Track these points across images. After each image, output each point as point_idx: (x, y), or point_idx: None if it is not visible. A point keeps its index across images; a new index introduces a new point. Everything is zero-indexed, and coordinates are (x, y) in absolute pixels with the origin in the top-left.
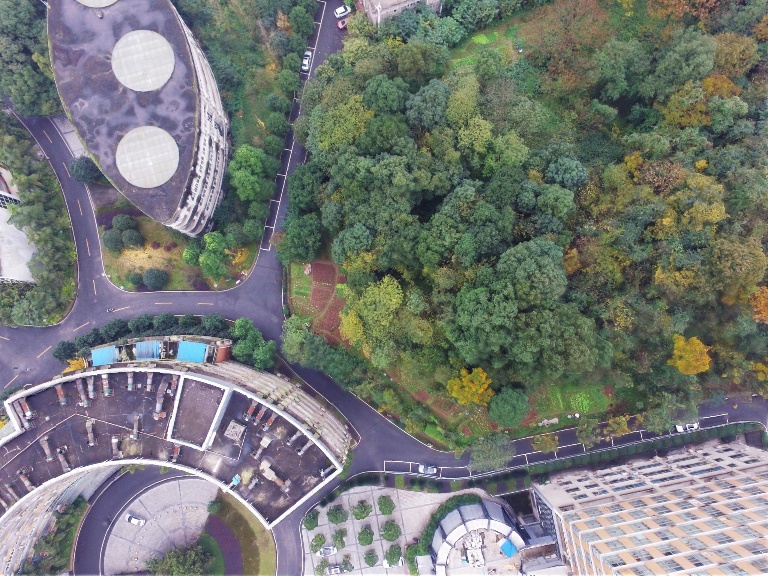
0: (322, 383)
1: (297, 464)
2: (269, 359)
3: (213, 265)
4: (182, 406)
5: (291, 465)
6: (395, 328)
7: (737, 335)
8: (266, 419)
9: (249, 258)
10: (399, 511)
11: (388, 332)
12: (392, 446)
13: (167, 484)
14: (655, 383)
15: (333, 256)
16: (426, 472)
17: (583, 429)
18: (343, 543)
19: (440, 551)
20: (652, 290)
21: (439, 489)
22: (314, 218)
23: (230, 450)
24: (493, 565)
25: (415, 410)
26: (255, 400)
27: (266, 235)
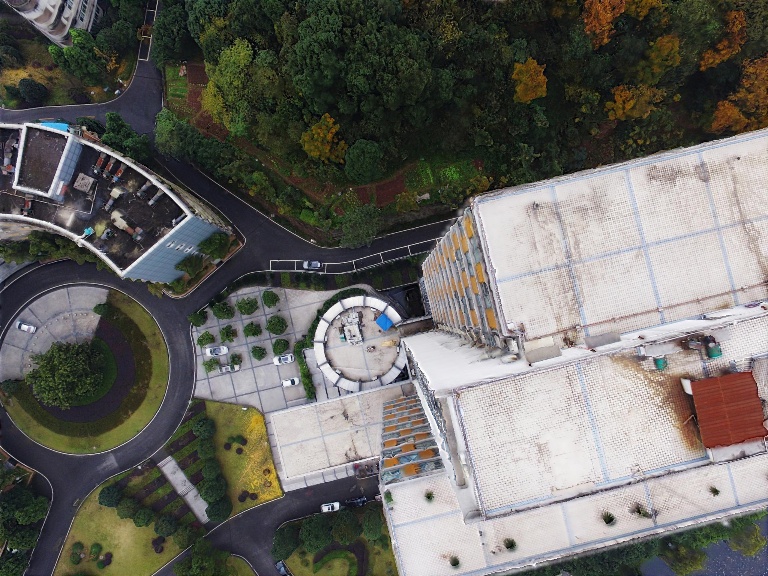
0: (205, 188)
1: (150, 216)
2: (142, 152)
3: (79, 58)
4: (27, 156)
5: (144, 217)
6: (249, 90)
7: (583, 69)
8: (116, 172)
9: (127, 68)
10: (287, 310)
11: (242, 95)
12: (277, 246)
13: (56, 292)
14: (509, 131)
15: (189, 29)
16: (310, 267)
17: (445, 189)
18: (229, 336)
19: (317, 329)
20: (487, 13)
21: (324, 283)
22: (178, 7)
23: (82, 204)
24: (372, 343)
25: (285, 189)
26: (102, 151)
27: (143, 45)
